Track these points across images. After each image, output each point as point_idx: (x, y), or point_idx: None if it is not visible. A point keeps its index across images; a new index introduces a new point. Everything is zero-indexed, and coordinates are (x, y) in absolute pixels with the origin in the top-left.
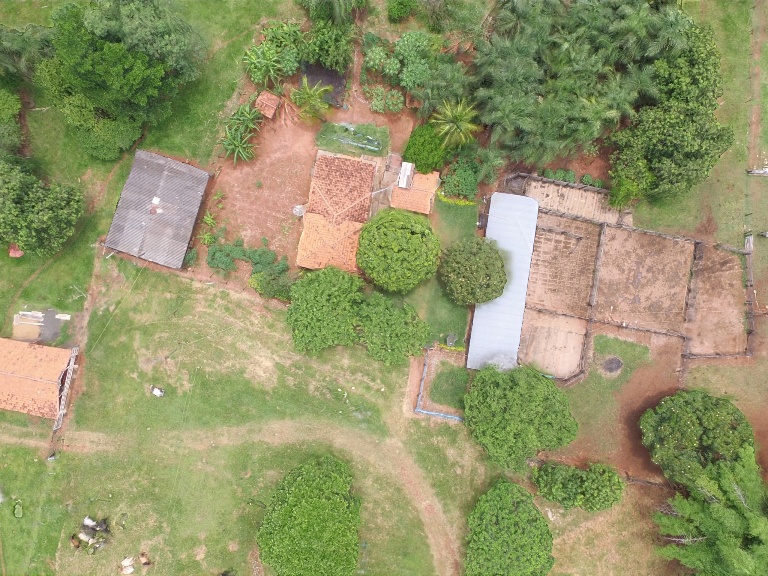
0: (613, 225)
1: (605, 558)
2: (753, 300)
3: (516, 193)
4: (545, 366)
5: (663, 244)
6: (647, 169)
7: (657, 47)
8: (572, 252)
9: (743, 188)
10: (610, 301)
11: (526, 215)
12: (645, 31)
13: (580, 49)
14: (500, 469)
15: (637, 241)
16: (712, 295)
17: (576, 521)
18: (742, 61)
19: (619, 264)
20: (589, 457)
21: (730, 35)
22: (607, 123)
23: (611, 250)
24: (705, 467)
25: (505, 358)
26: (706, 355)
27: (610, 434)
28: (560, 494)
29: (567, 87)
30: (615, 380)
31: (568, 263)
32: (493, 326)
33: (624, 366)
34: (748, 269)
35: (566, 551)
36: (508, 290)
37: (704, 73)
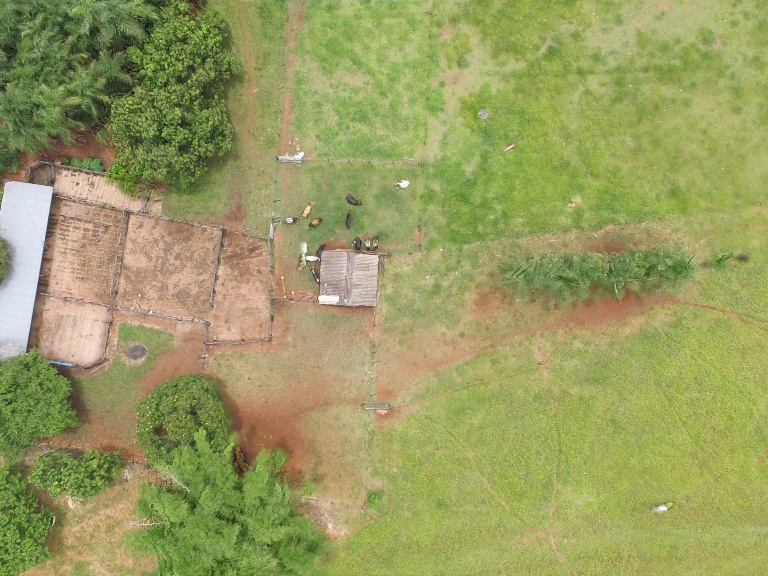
0: (135, 213)
1: (124, 545)
2: (279, 286)
3: (33, 181)
4: (71, 354)
5: (191, 231)
6: (133, 156)
7: (108, 33)
8: (100, 240)
9: (273, 175)
10: (138, 289)
11: (38, 203)
12: (92, 17)
13: (45, 36)
14: (21, 458)
15: (165, 228)
16: (241, 282)
17: (96, 509)
18: (276, 48)
19: (147, 252)
20: (113, 445)
21: (265, 22)
22: (75, 110)
23: (139, 238)
24: (169, 452)
25: (14, 346)
26: (231, 341)
27: (135, 421)
28: (35, 481)
29: (31, 74)
30: (139, 367)
31: (96, 251)
32: (1, 315)
33: (148, 353)
34: (276, 255)
35: (86, 539)
36: (18, 278)
37: (168, 59)
